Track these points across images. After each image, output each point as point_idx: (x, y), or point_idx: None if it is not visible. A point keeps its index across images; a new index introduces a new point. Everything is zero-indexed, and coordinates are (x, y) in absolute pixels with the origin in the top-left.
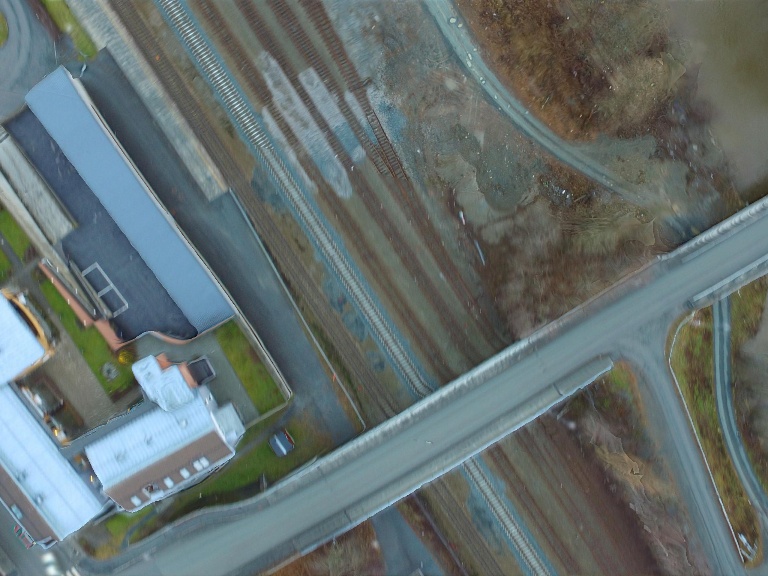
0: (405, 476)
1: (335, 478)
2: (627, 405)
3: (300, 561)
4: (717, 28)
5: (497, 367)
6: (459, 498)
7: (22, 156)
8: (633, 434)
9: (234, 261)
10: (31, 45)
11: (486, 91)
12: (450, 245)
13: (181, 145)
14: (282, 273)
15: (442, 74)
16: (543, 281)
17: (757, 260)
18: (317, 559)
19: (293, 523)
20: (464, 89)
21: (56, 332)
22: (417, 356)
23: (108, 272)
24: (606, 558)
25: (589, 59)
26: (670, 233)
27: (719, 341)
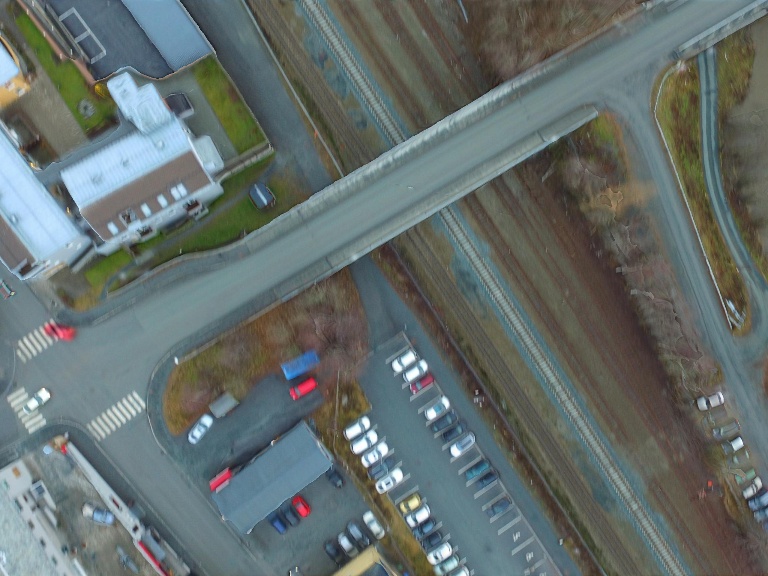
0: (387, 222)
1: (316, 224)
2: (612, 159)
3: (281, 310)
4: None
5: (480, 112)
6: (443, 260)
7: None
8: None
9: (214, 15)
10: None
11: None
12: (433, 2)
13: None
14: (262, 27)
15: None
16: (525, 12)
17: (743, 8)
18: (298, 306)
19: (274, 271)
20: None
21: (32, 67)
22: (400, 115)
23: (85, 18)
24: (592, 324)
25: None
26: None
27: (706, 105)
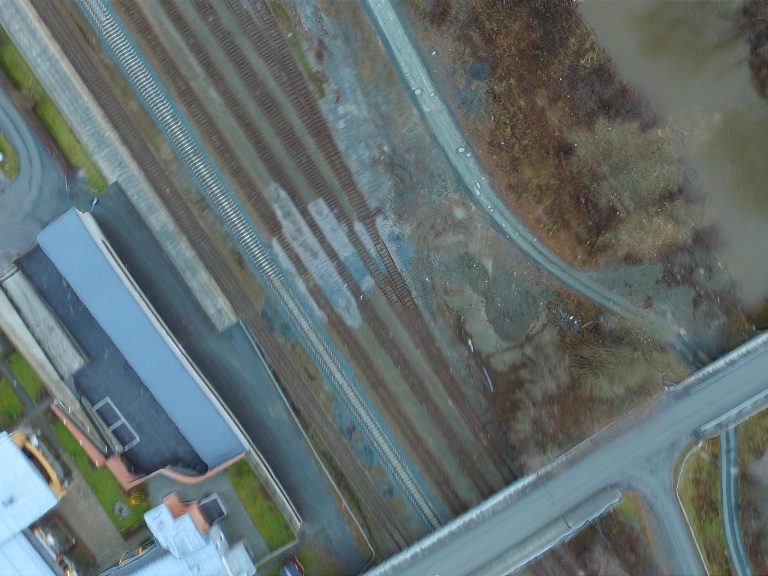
0: None
1: None
2: (635, 533)
3: None
4: (724, 155)
5: (506, 500)
6: None
7: (34, 290)
8: (641, 560)
9: (244, 391)
10: (42, 179)
11: (494, 219)
12: (459, 372)
13: (191, 277)
14: (292, 402)
15: (450, 203)
16: (552, 421)
17: (764, 391)
18: None
19: None
20: (472, 217)
21: (68, 472)
22: (426, 482)
23: (119, 406)
24: None
25: (596, 186)
26: (677, 357)
27: (726, 464)
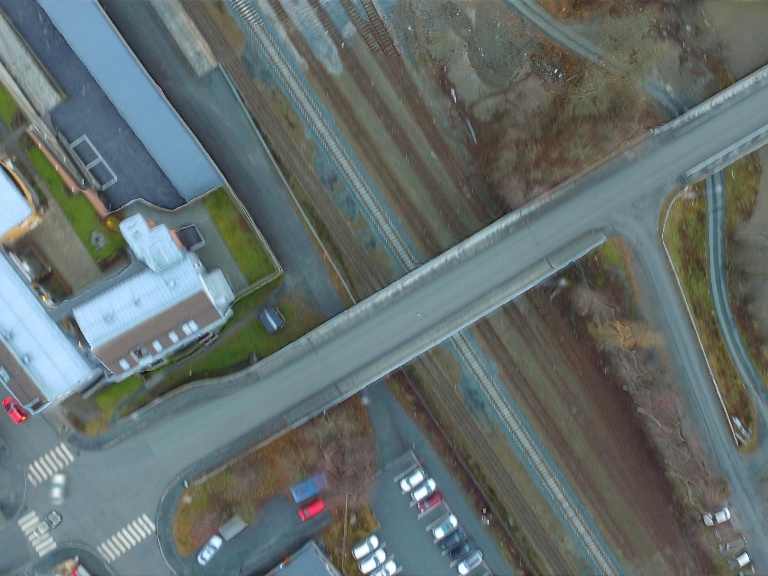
0: (396, 349)
1: (326, 351)
2: (620, 282)
3: (291, 436)
4: None
5: (489, 239)
6: (451, 379)
7: (10, 29)
8: (626, 313)
9: (224, 137)
10: None
11: None
12: (441, 123)
13: (170, 19)
14: (272, 150)
15: None
16: (534, 146)
17: (750, 134)
18: (308, 432)
19: (283, 397)
20: None
21: (44, 199)
22: (408, 235)
23: (97, 145)
24: (599, 441)
25: None
26: (663, 113)
27: (713, 223)
